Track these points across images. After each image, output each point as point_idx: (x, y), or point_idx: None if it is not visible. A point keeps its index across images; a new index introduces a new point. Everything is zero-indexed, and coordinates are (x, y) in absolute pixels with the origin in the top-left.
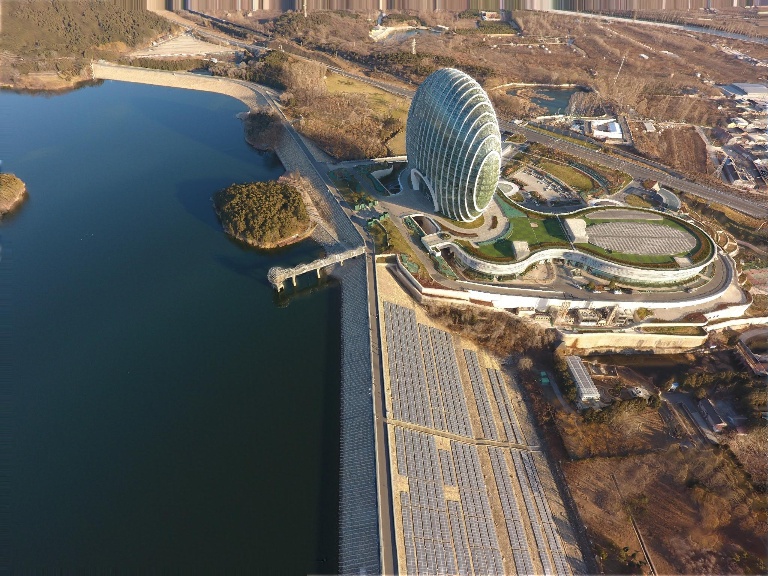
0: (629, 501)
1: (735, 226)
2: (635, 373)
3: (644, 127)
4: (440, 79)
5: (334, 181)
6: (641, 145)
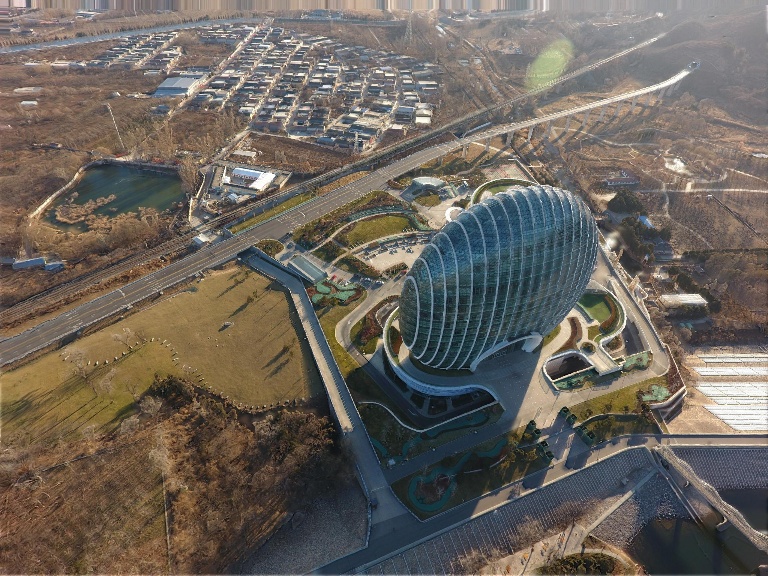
0: (767, 309)
1: (436, 170)
2: (642, 273)
3: (246, 156)
4: (522, 217)
5: (459, 501)
6: (305, 168)
